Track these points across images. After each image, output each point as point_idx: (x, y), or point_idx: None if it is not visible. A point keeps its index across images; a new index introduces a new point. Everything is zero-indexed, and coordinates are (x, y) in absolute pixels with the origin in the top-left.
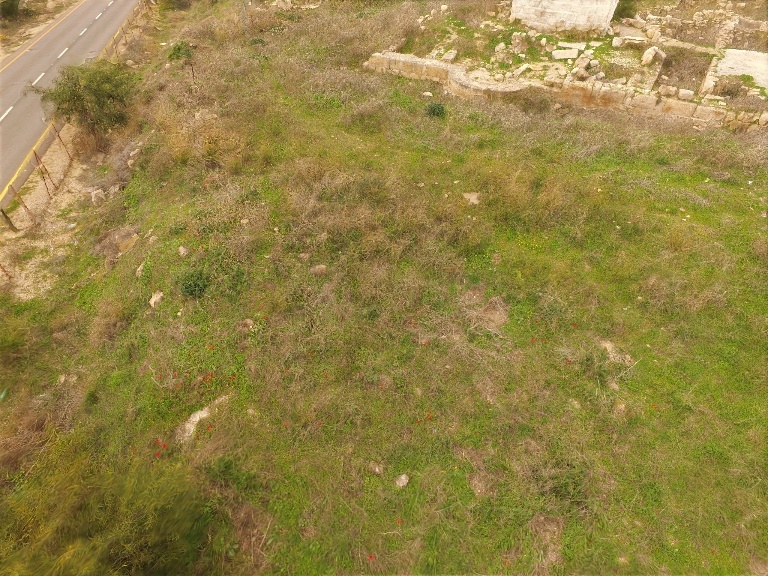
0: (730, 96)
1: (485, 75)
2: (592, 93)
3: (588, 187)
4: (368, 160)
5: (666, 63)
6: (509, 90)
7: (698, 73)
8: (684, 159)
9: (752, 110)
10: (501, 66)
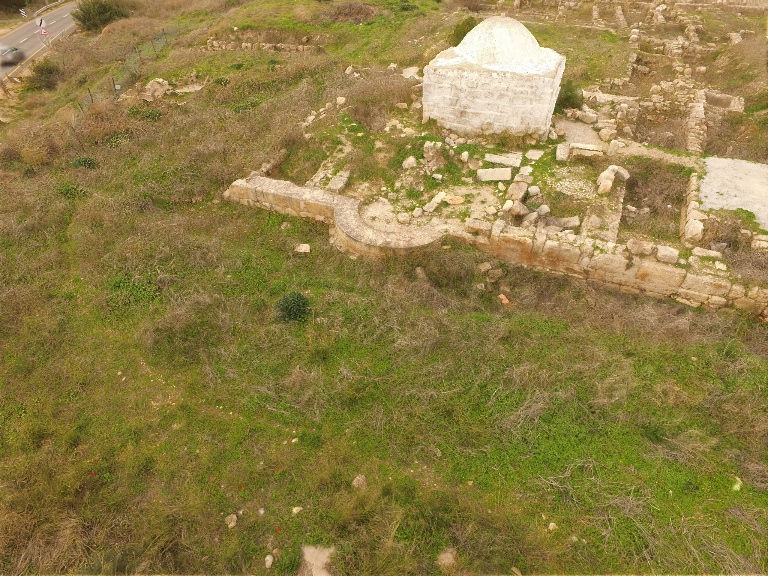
0: (726, 243)
1: (386, 212)
2: (533, 248)
3: (531, 527)
4: (147, 456)
5: (630, 182)
6: (415, 244)
7: (674, 198)
8: (691, 431)
9: None
10: (409, 195)
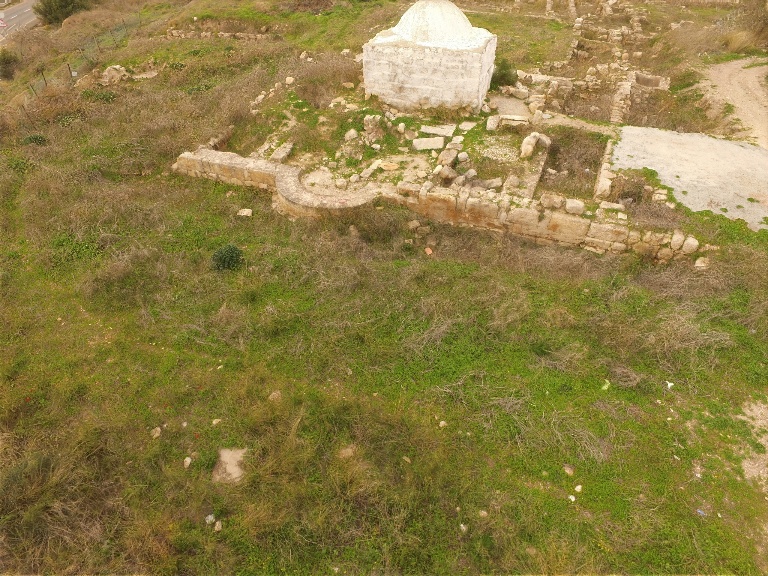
0: (632, 198)
1: (325, 179)
2: (457, 206)
3: (422, 423)
4: (80, 383)
5: (553, 149)
6: (350, 205)
7: (592, 162)
8: (571, 344)
9: (660, 229)
10: (348, 163)
